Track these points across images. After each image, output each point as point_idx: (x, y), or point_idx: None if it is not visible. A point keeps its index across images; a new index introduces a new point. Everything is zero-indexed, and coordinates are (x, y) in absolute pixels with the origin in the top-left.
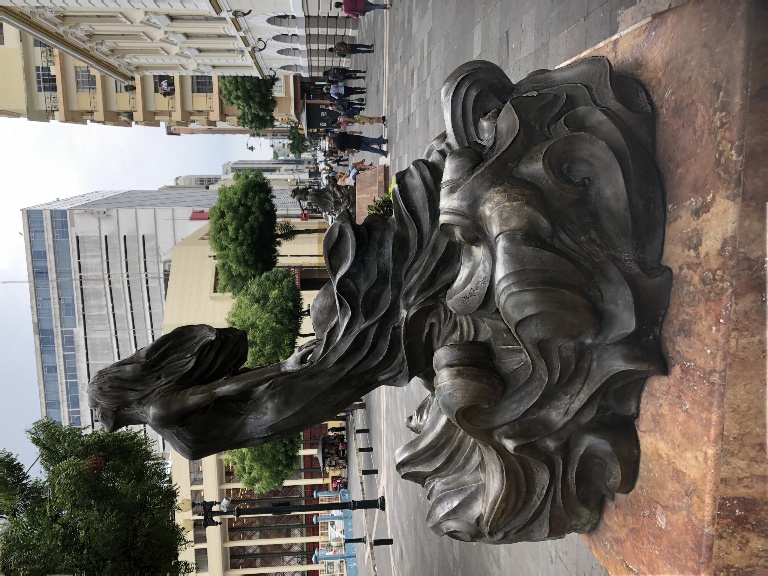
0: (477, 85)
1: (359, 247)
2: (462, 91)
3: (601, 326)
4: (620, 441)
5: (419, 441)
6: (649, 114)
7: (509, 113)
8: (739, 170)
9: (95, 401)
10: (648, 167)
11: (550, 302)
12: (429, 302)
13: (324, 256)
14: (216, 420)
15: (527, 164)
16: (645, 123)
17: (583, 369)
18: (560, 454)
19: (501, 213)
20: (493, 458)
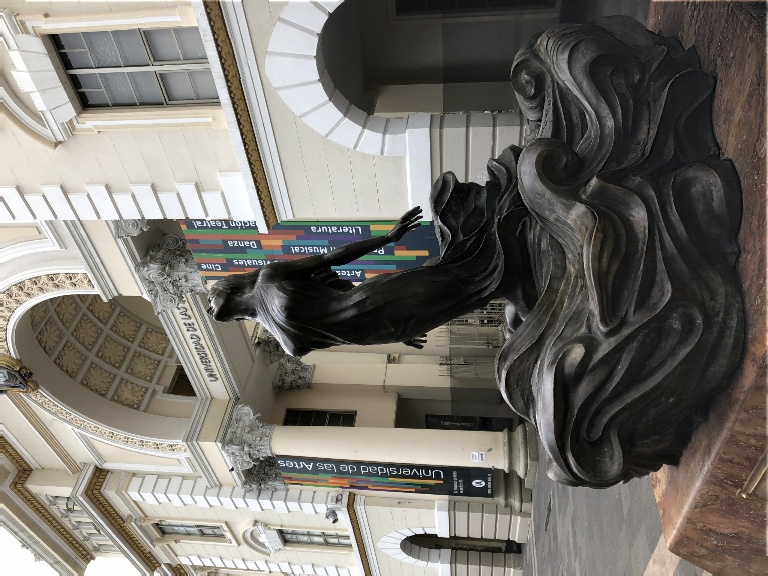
0: None
1: (459, 190)
2: None
3: (643, 69)
4: (706, 159)
5: None
6: None
7: None
8: None
9: (215, 289)
10: None
11: None
12: None
13: (431, 204)
14: (316, 288)
15: None
16: None
17: (644, 111)
18: (648, 183)
19: None
20: (582, 212)
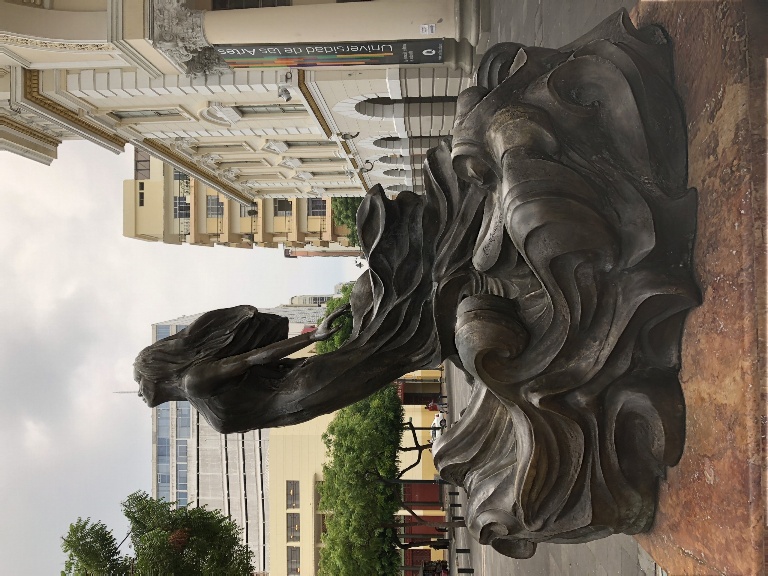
0: (502, 58)
1: (390, 220)
2: (487, 64)
3: (621, 249)
4: (660, 394)
5: (456, 429)
6: (664, 45)
7: (519, 54)
8: (743, 50)
9: (139, 373)
10: (665, 92)
11: (556, 212)
12: (460, 273)
13: (358, 232)
14: (248, 393)
15: (533, 90)
16: (660, 53)
17: (608, 306)
18: (593, 411)
19: (504, 131)
20: (521, 420)
